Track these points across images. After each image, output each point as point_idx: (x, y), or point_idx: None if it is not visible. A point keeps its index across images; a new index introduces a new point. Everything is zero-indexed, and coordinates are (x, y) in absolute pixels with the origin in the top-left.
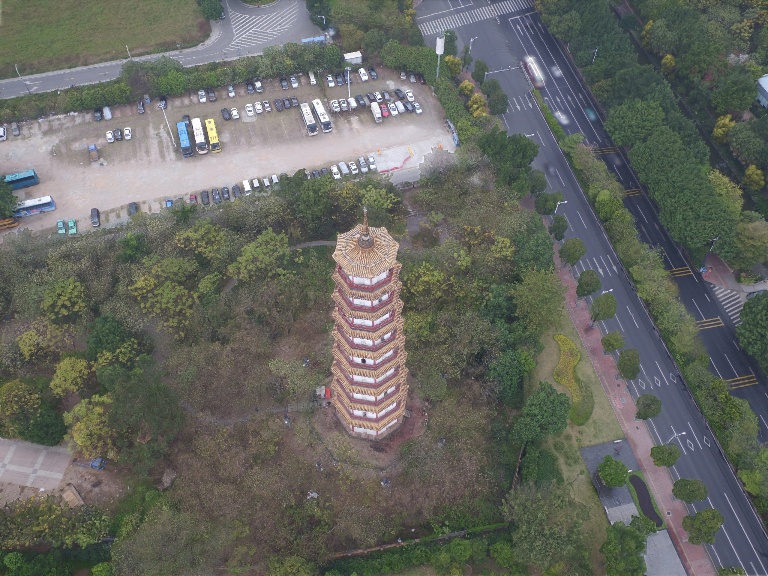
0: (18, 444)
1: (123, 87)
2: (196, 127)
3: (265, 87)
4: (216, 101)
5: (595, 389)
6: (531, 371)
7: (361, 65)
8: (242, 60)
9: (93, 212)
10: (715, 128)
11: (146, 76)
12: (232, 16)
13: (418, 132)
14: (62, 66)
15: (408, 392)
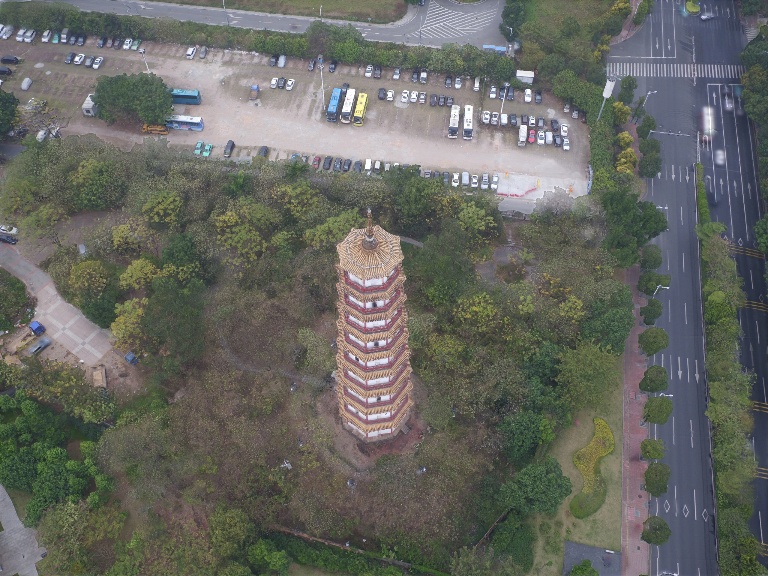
0: (82, 316)
1: (302, 42)
2: (348, 97)
3: (430, 79)
4: (379, 79)
5: (612, 489)
6: (552, 442)
7: (530, 86)
8: (417, 48)
9: (229, 143)
10: None
11: (326, 38)
12: (431, 5)
13: (555, 168)
14: (265, 9)
15: (417, 410)
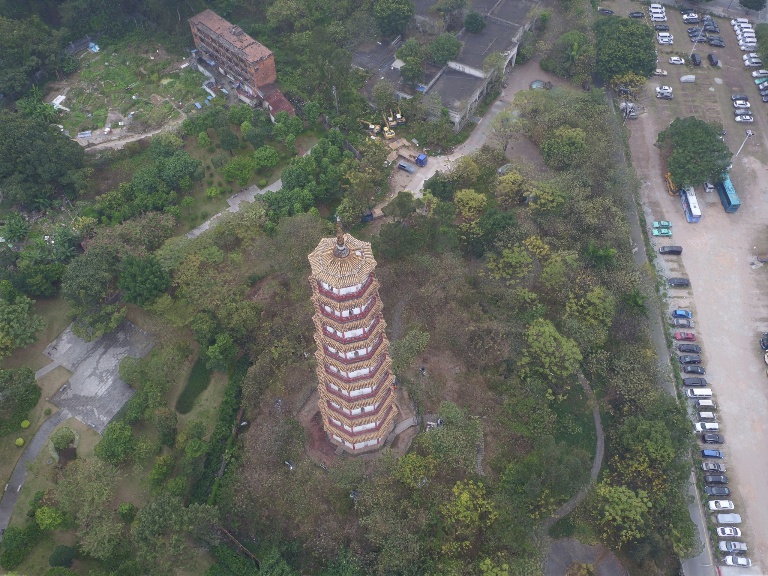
0: None
1: None
2: None
3: None
4: None
5: None
6: None
7: None
8: None
9: (676, 247)
10: None
11: None
12: None
13: None
14: None
15: None
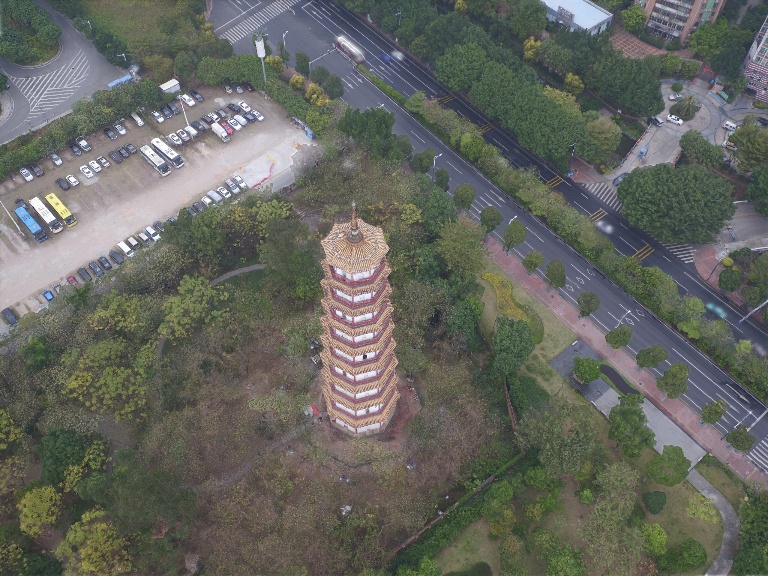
0: None
1: None
2: (39, 207)
3: (91, 144)
4: (44, 174)
5: (536, 307)
6: None
7: (181, 92)
8: (56, 123)
9: None
10: (525, 52)
11: None
12: (16, 83)
13: (269, 138)
14: None
15: None
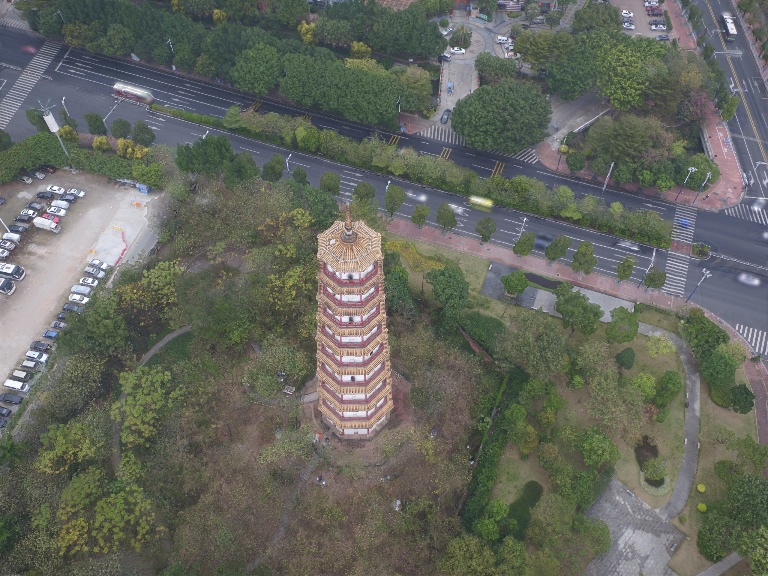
0: None
1: None
2: None
3: None
4: None
5: (443, 253)
6: None
7: None
8: None
9: None
10: (303, 37)
11: None
12: None
13: (102, 210)
14: None
15: None
